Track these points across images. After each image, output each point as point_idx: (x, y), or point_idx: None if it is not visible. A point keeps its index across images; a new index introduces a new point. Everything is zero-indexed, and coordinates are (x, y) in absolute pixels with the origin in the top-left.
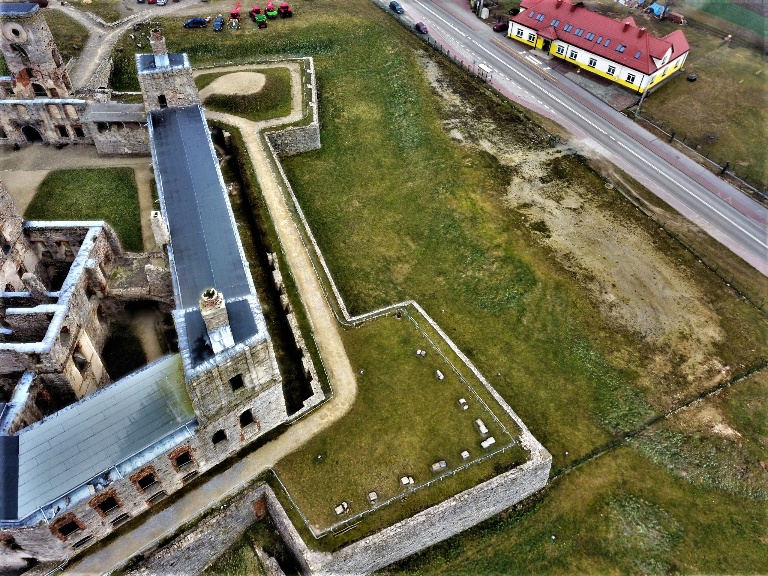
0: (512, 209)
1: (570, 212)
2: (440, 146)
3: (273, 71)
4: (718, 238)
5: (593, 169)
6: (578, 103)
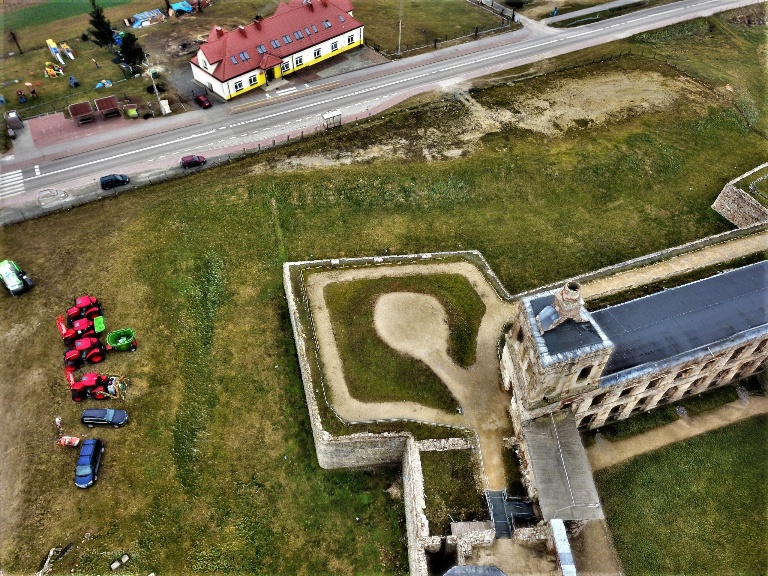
0: (565, 133)
1: (556, 106)
2: (479, 165)
3: (338, 300)
4: (553, 55)
5: (490, 87)
6: (376, 79)
